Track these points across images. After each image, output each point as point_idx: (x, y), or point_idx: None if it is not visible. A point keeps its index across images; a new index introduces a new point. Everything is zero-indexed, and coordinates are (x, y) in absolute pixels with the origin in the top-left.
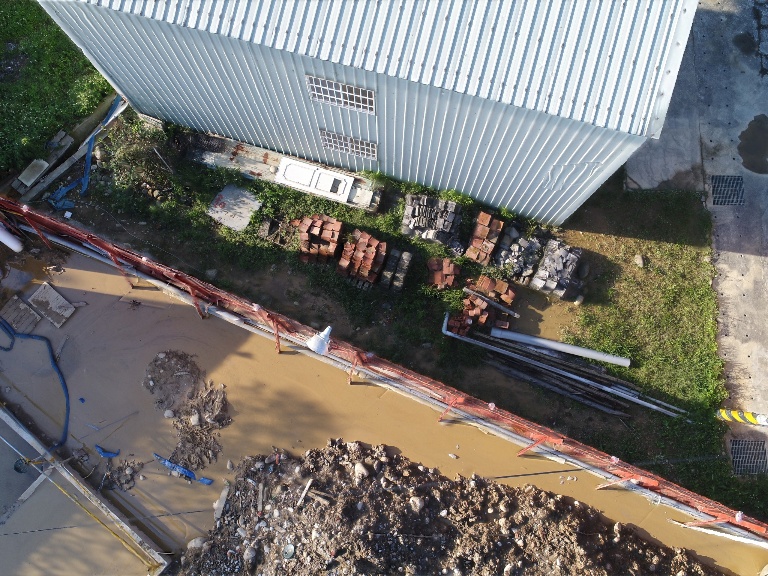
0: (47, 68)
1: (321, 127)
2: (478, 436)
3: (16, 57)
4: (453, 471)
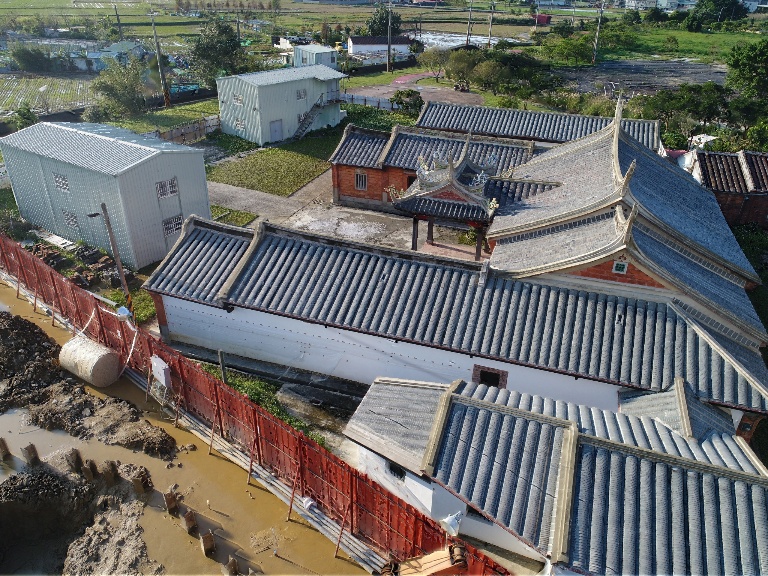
0: (8, 207)
1: (62, 208)
2: (26, 304)
3: (3, 206)
4: (3, 310)
